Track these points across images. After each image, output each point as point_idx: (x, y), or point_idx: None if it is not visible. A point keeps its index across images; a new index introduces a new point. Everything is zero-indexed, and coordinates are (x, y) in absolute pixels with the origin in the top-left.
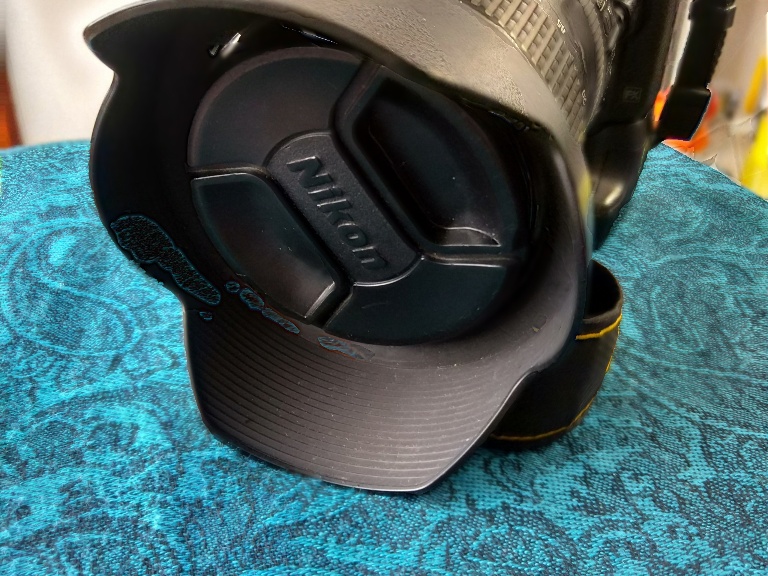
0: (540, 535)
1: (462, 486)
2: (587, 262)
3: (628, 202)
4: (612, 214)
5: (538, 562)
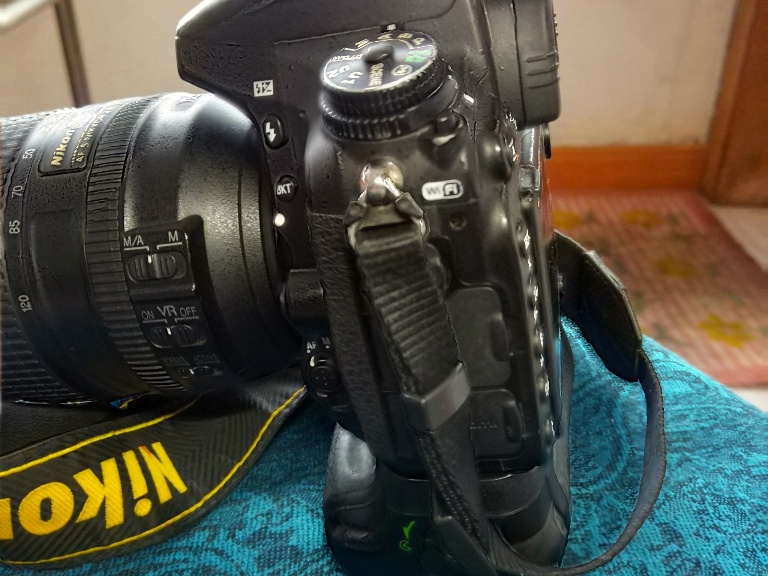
0: None
1: None
2: None
3: None
4: (345, 550)
5: None
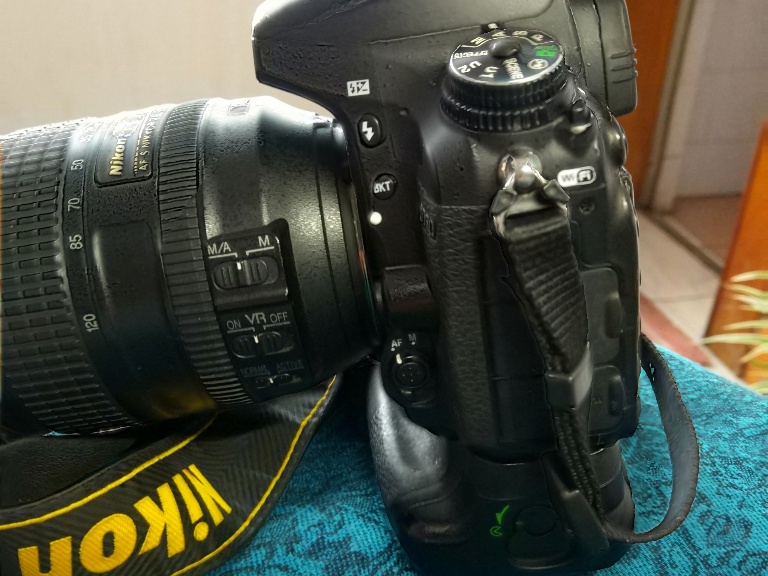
0: None
1: None
2: None
3: None
4: (425, 546)
5: None
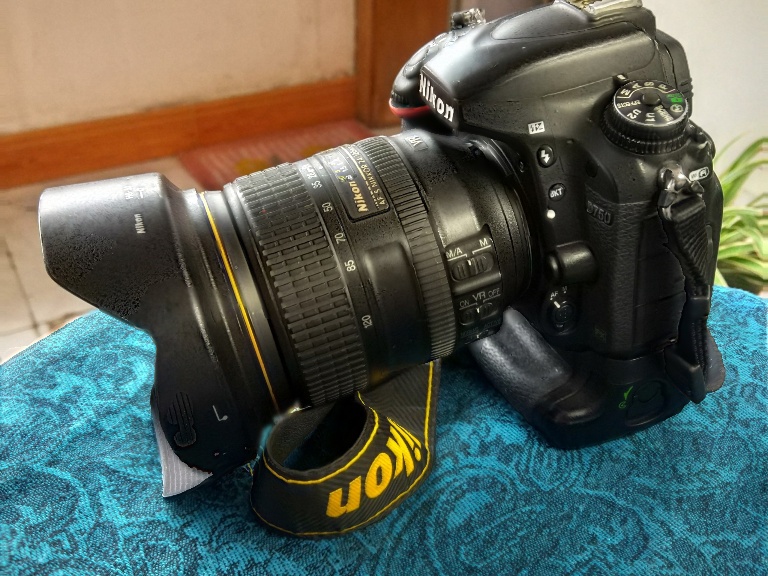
0: (182, 566)
1: (199, 515)
2: (197, 420)
3: (675, 431)
4: (571, 427)
5: (159, 575)
